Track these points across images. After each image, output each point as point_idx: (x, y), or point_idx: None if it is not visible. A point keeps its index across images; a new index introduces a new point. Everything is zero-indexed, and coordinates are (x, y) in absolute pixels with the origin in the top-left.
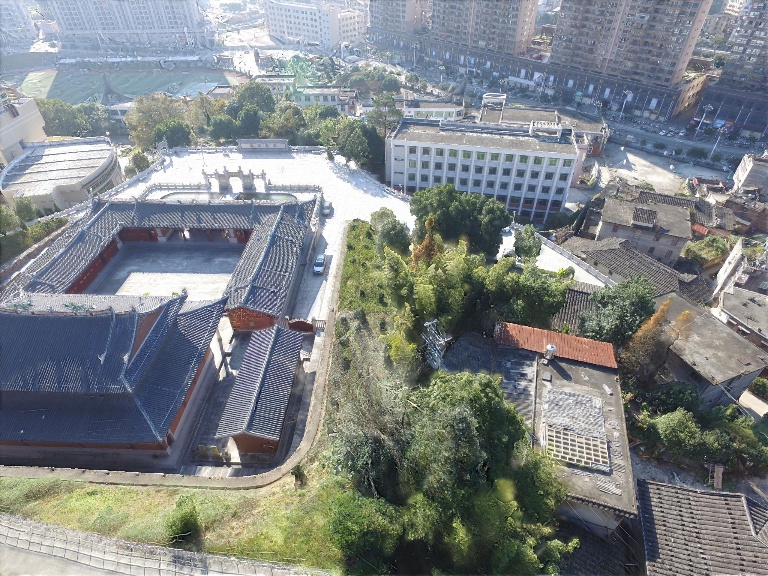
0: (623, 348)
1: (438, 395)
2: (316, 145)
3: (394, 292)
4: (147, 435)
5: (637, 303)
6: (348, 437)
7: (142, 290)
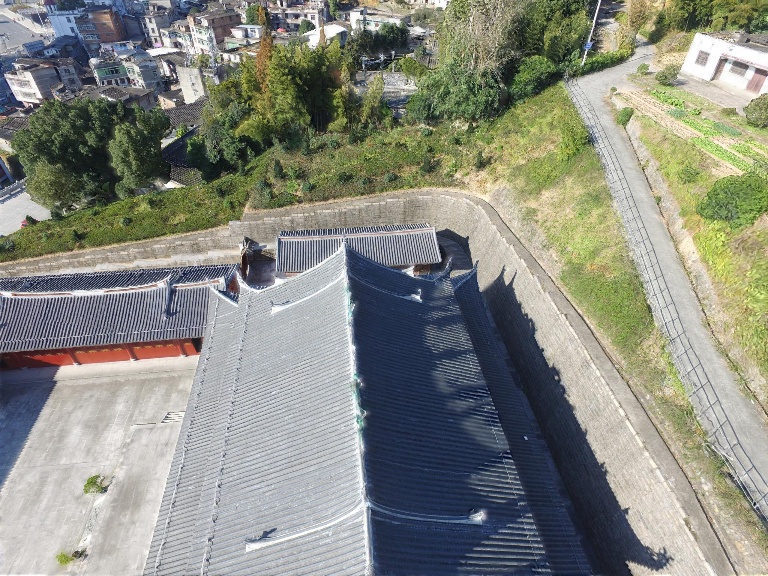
0: None
1: (479, 0)
2: None
3: (305, 90)
4: (473, 286)
5: None
6: (497, 56)
7: None
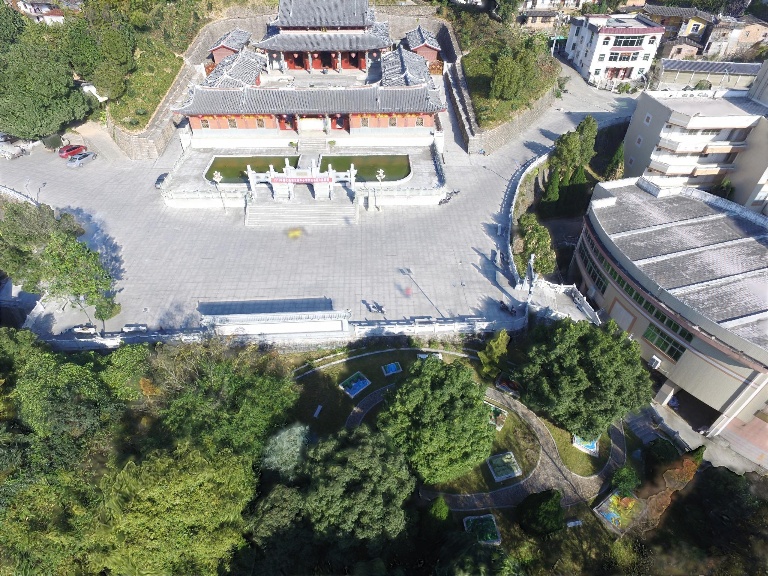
0: None
1: None
2: None
3: None
4: None
5: None
6: None
7: None
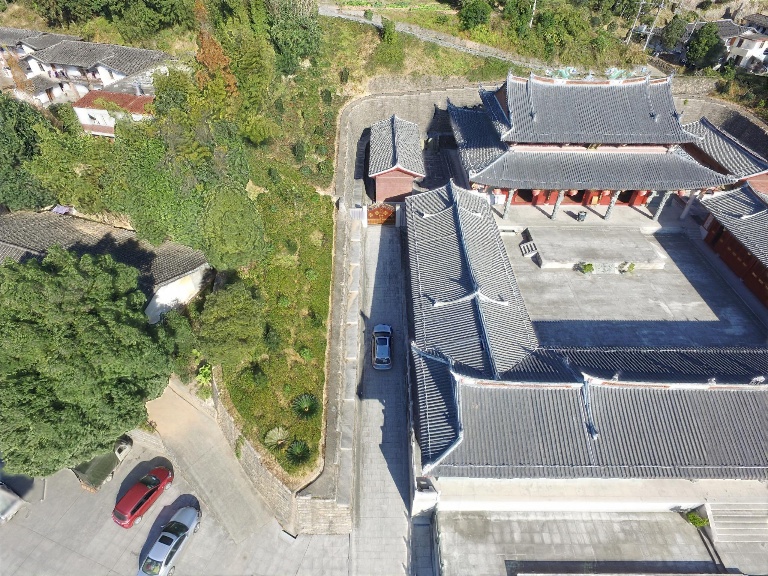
0: (53, 125)
1: None
2: None
3: None
4: None
5: None
6: None
7: (656, 287)
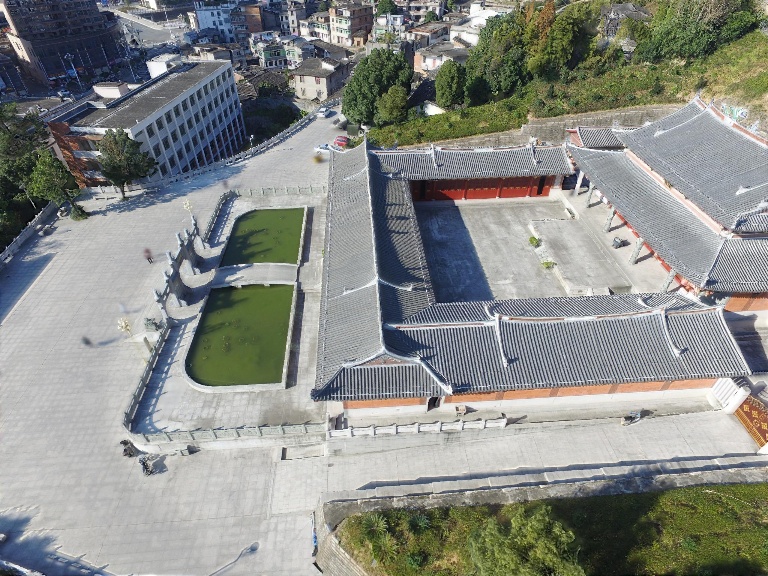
0: None
1: None
2: (15, 230)
3: None
4: None
5: (512, 21)
6: None
7: (533, 283)
